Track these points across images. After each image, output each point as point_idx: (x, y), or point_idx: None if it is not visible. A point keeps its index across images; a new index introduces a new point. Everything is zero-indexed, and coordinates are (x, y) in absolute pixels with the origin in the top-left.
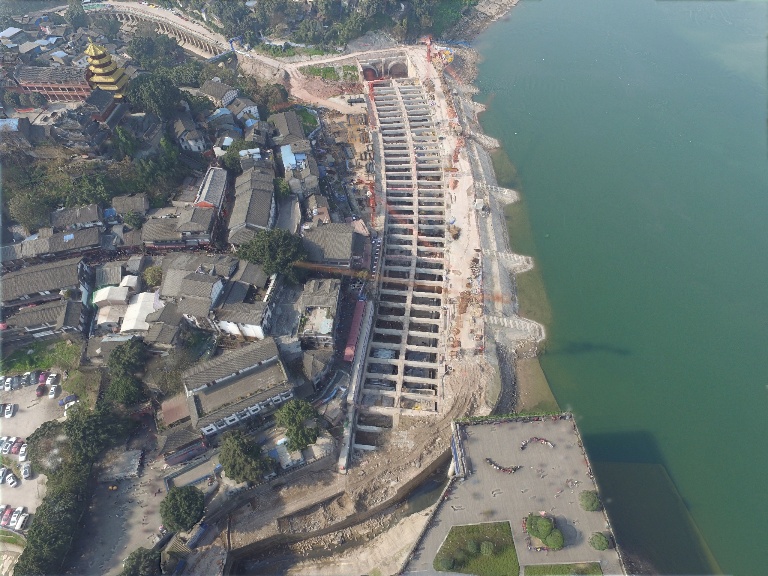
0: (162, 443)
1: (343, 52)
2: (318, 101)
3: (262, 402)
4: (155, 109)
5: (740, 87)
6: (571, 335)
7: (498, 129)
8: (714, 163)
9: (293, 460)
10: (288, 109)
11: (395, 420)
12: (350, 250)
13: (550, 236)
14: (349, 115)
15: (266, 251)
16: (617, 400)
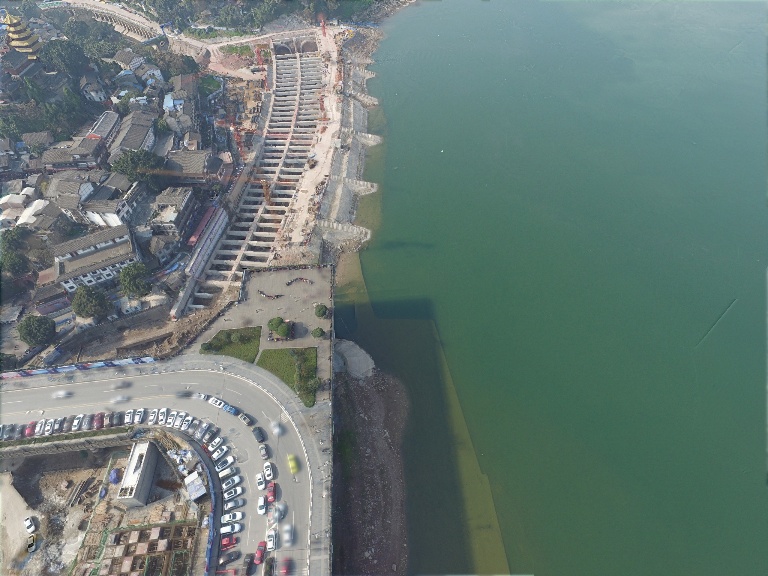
0: (34, 295)
1: (259, 33)
2: (229, 72)
3: (112, 268)
4: (63, 67)
5: (602, 51)
6: (391, 237)
7: (381, 91)
8: (557, 111)
9: (131, 307)
10: (189, 73)
11: (225, 289)
12: (203, 166)
13: (398, 168)
14: (250, 81)
15: (129, 163)
16: (413, 279)
